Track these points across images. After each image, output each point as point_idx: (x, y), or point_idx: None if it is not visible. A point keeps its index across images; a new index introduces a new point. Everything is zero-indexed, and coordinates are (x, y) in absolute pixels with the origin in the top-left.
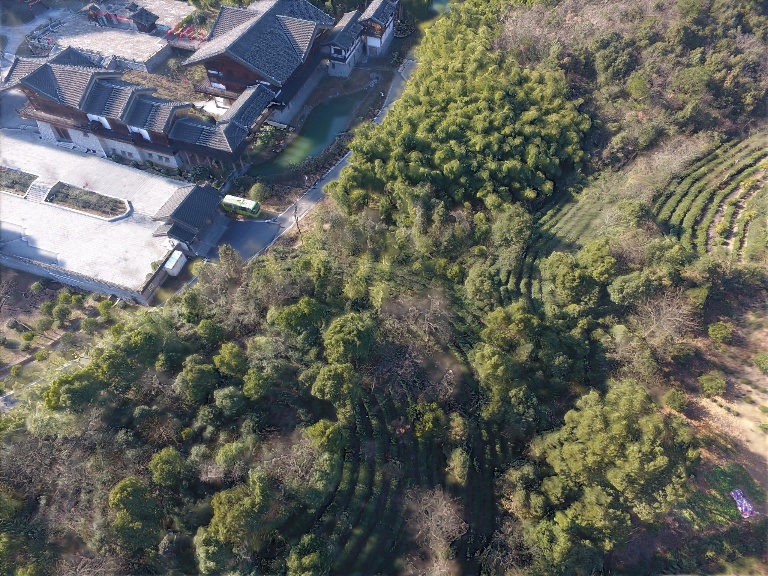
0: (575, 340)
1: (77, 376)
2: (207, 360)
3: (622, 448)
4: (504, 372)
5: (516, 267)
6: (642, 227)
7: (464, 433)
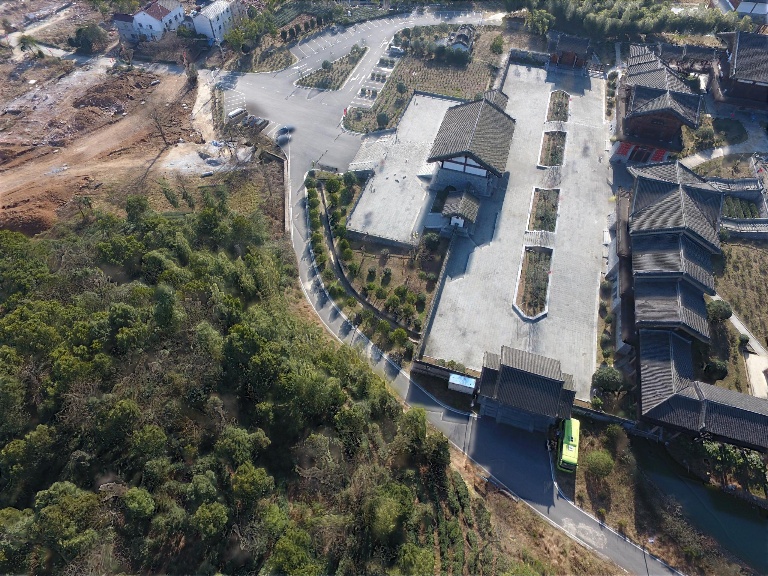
0: None
1: (252, 341)
2: (283, 451)
3: None
4: None
5: None
6: None
7: None
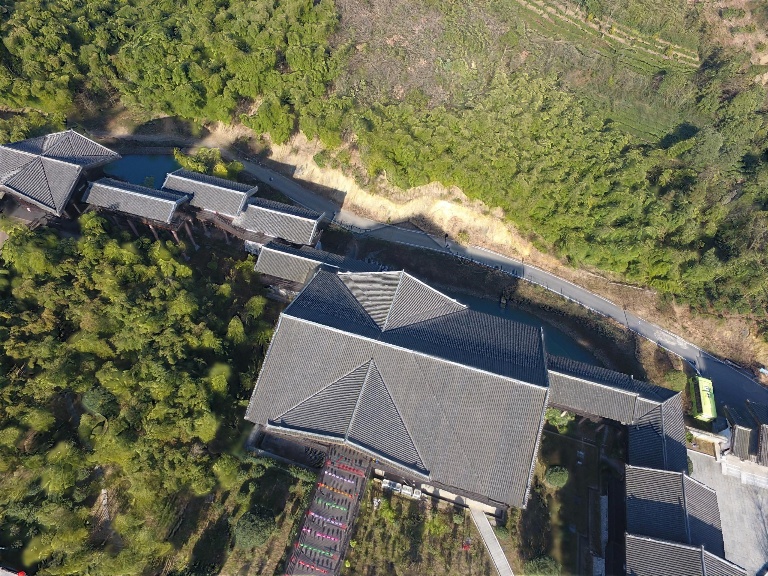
0: None
1: None
2: None
3: None
4: None
5: None
6: None
7: None
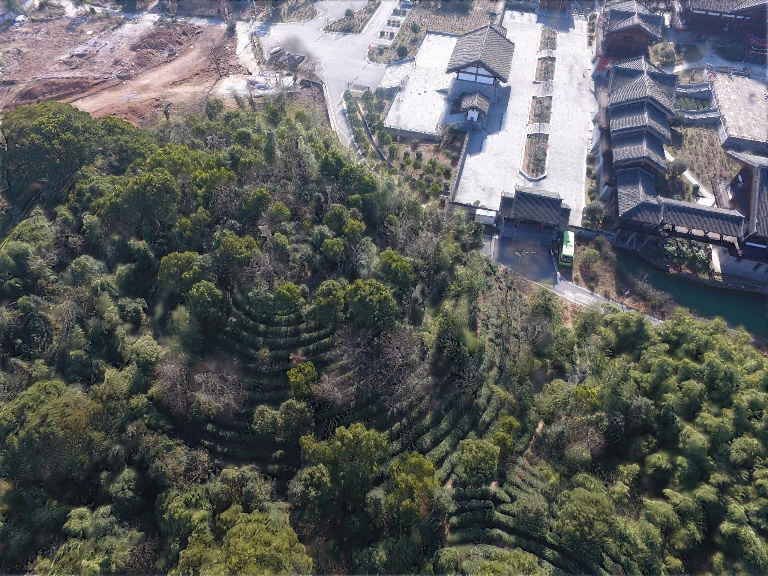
0: None
1: (340, 160)
2: None
3: (233, 575)
4: (338, 450)
5: (519, 517)
6: None
7: (285, 413)
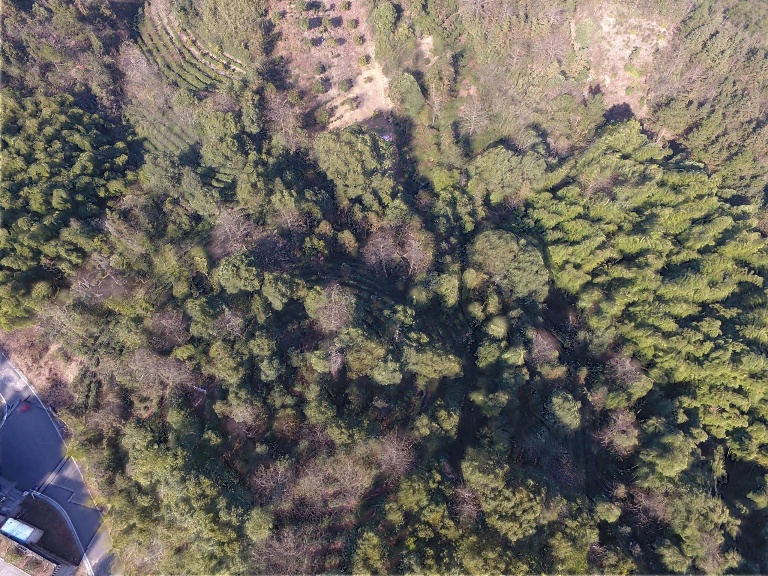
0: (277, 163)
1: None
2: None
3: None
4: None
5: (201, 180)
6: (202, 99)
7: None
